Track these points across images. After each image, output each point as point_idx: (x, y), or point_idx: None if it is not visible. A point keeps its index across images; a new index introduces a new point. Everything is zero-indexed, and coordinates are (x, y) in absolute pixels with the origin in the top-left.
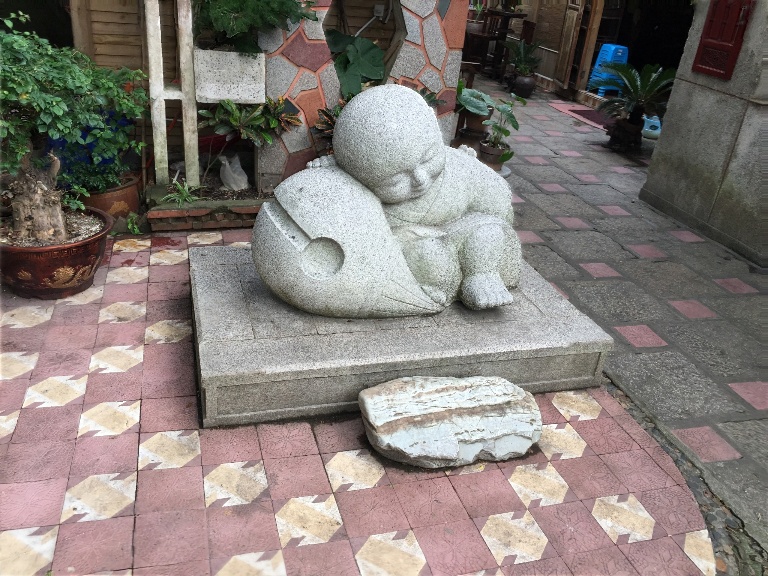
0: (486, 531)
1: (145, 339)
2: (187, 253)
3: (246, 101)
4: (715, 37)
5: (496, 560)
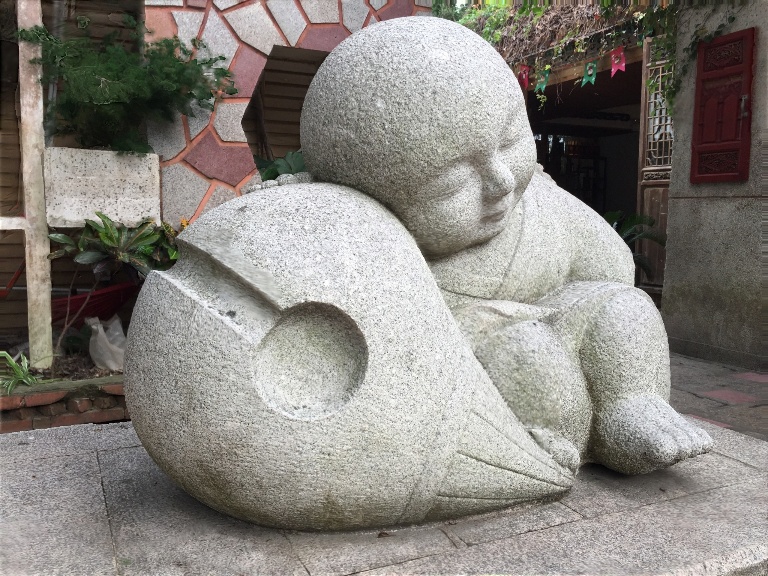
0: None
1: None
2: None
3: (130, 224)
4: (711, 140)
5: None
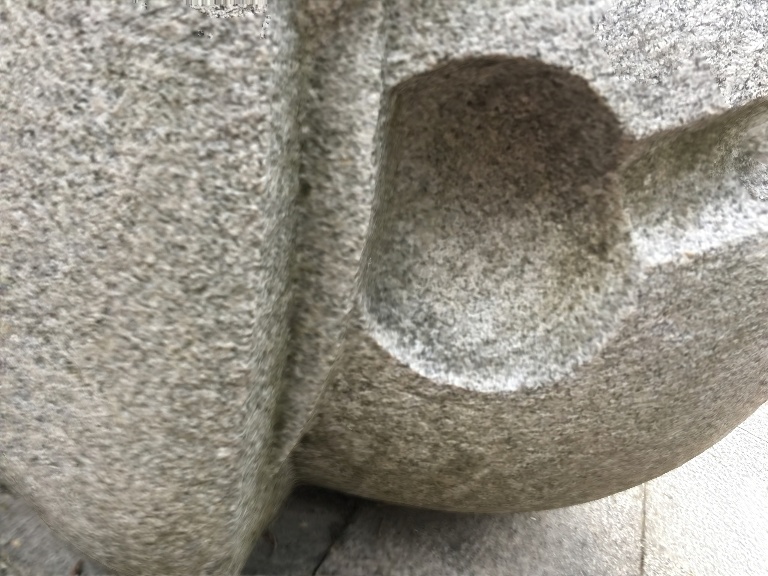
0: None
1: None
2: None
3: None
4: None
5: None
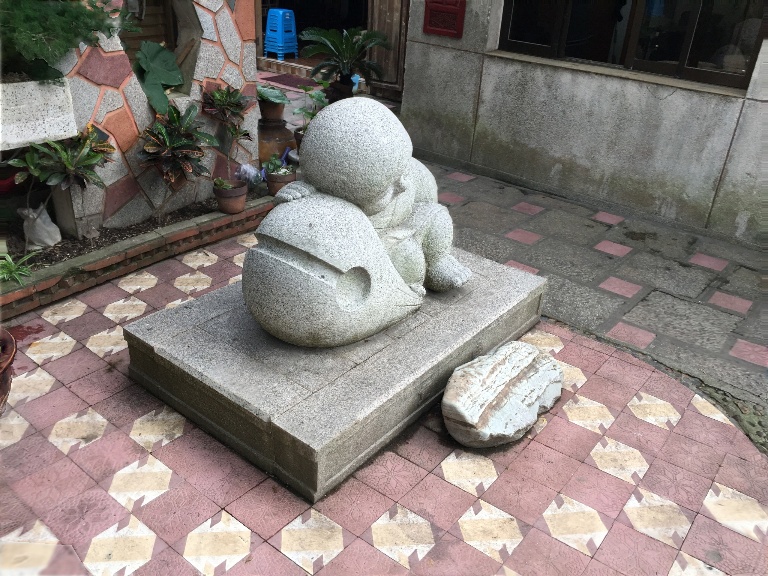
0: (601, 466)
1: (144, 447)
2: (68, 336)
3: (56, 138)
4: (440, 1)
5: (630, 483)
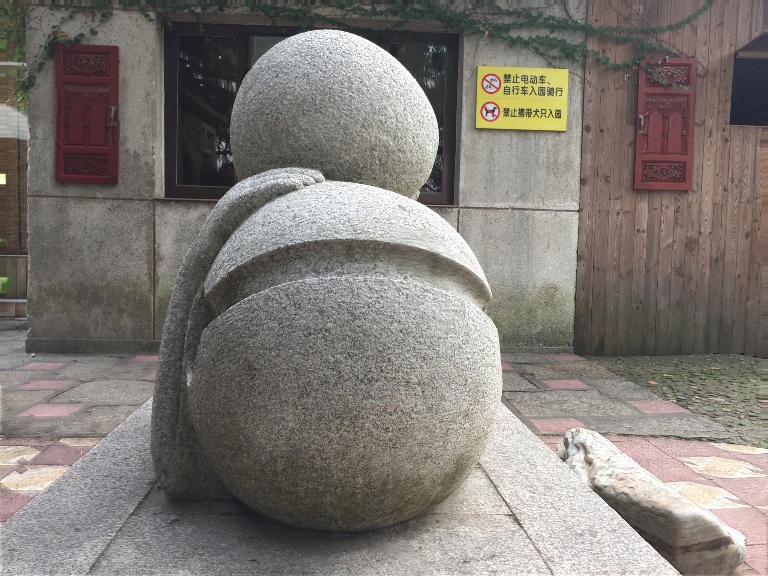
0: None
1: None
2: None
3: None
4: (80, 142)
5: None
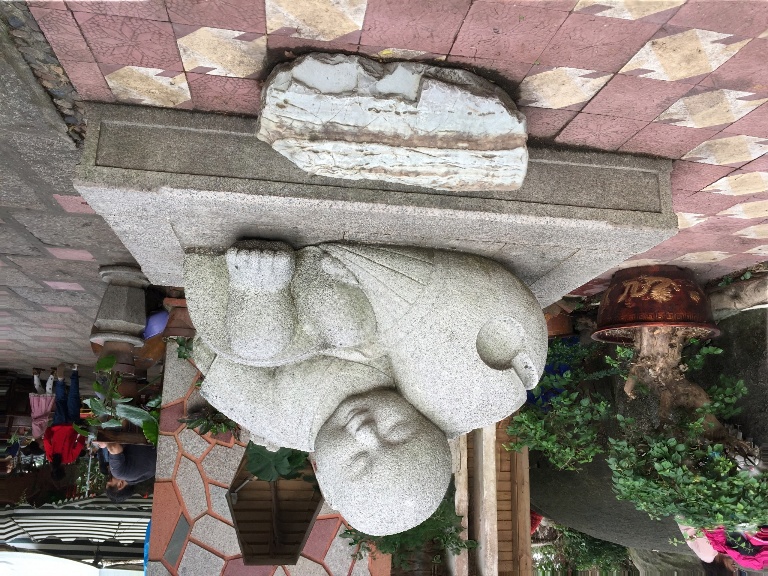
0: None
1: None
2: None
3: None
4: None
5: None
